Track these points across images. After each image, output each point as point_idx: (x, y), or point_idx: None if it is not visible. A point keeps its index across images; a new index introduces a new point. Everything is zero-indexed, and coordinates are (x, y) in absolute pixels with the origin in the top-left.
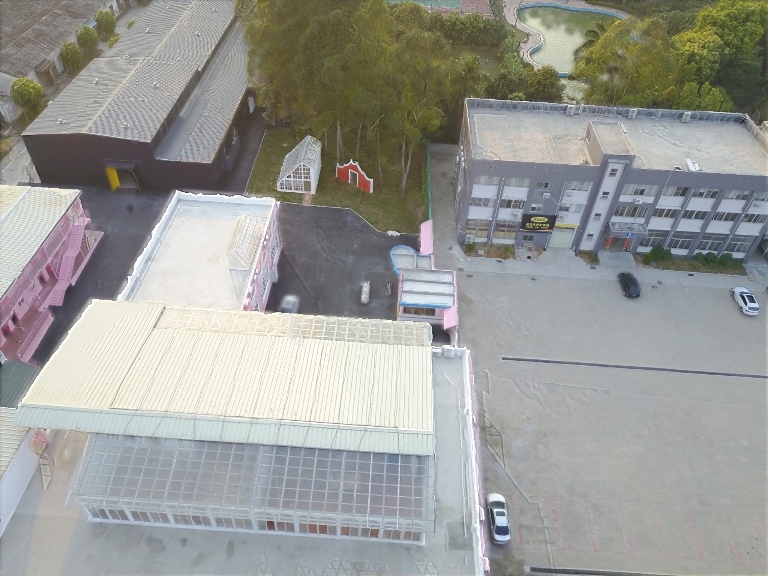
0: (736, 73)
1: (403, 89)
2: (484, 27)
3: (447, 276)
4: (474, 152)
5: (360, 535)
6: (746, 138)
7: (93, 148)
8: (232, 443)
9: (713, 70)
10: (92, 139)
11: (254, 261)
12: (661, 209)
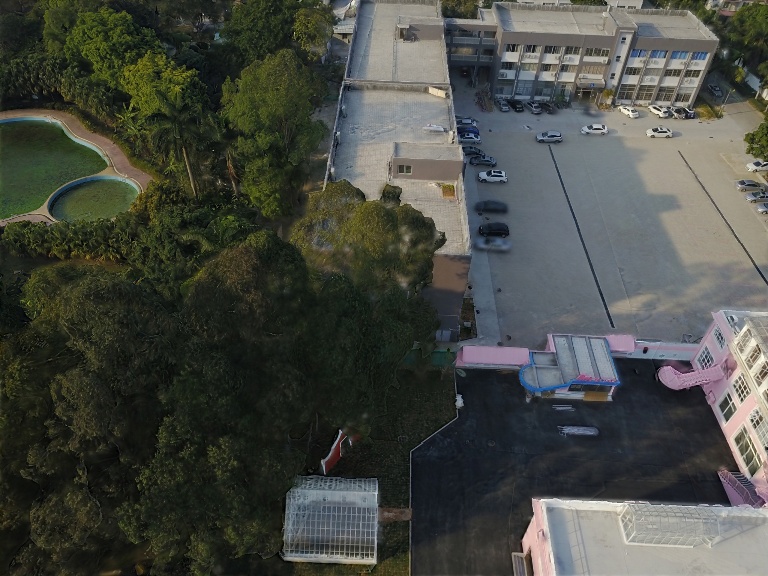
0: None
1: None
2: None
3: (559, 341)
4: None
5: None
6: (373, 94)
7: None
8: None
9: None
10: None
11: None
12: None
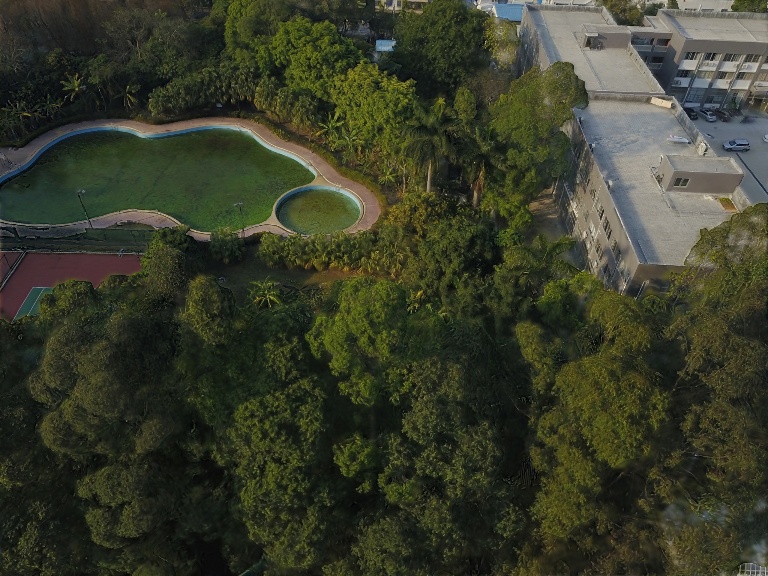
0: None
1: None
2: None
3: None
4: None
5: None
6: (595, 104)
7: None
8: None
9: None
10: None
11: None
12: None
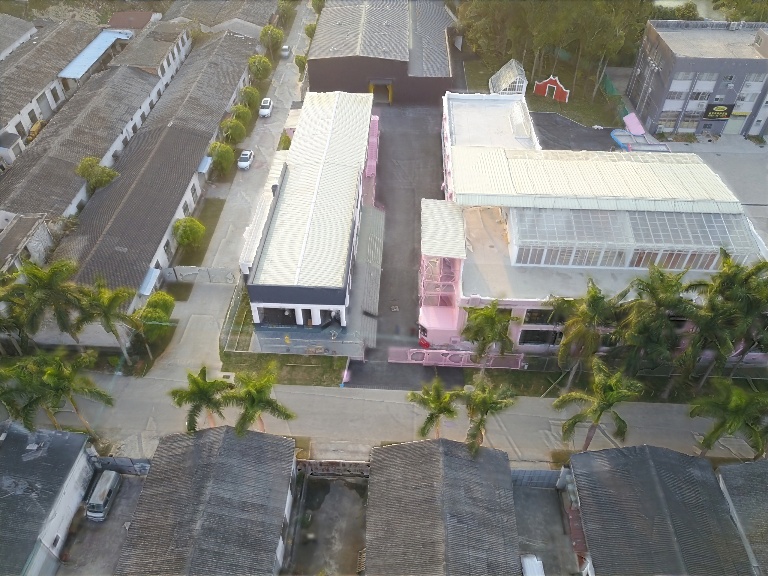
0: None
1: (621, 5)
2: None
3: (662, 147)
4: None
5: (698, 267)
6: None
7: (361, 68)
8: (607, 210)
9: None
10: (363, 60)
11: (532, 131)
12: None
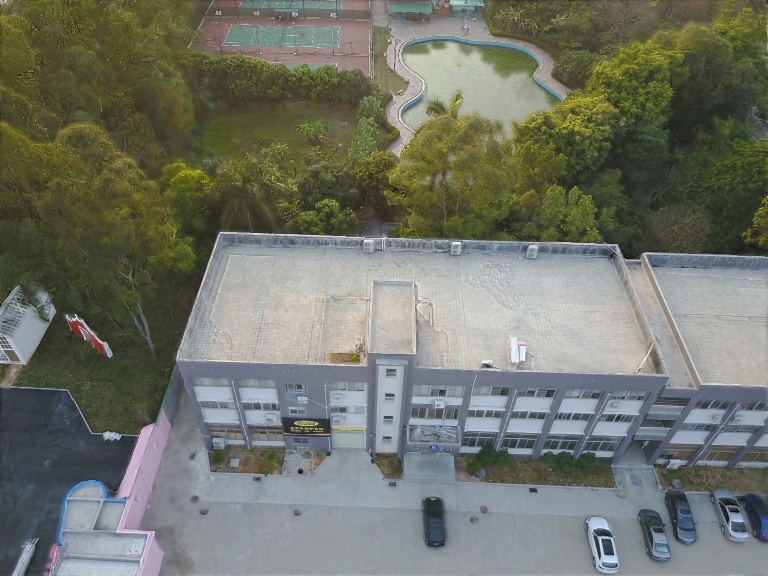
0: (635, 151)
1: (64, 258)
2: (339, 82)
3: (137, 543)
4: (198, 335)
5: None
6: (612, 285)
7: None
8: None
9: (603, 150)
10: None
11: None
12: (478, 410)
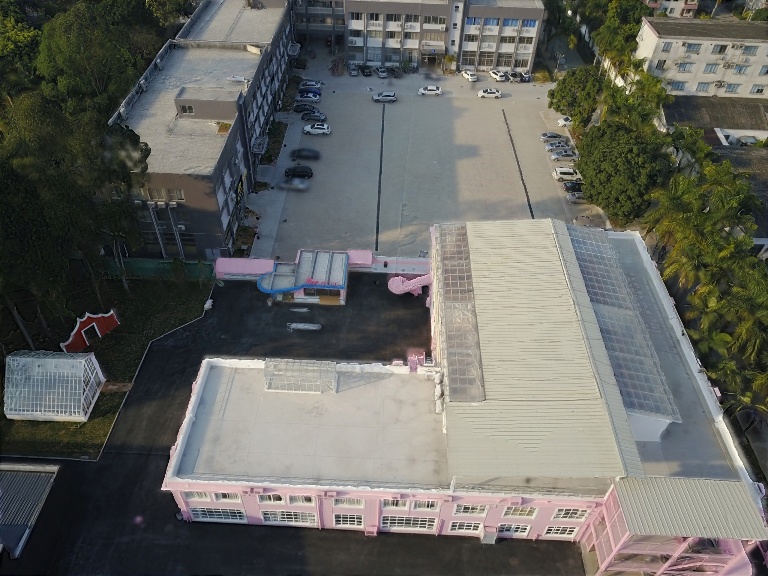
0: None
1: None
2: None
3: (306, 255)
4: None
5: None
6: (196, 52)
7: None
8: None
9: None
10: None
11: None
12: None
